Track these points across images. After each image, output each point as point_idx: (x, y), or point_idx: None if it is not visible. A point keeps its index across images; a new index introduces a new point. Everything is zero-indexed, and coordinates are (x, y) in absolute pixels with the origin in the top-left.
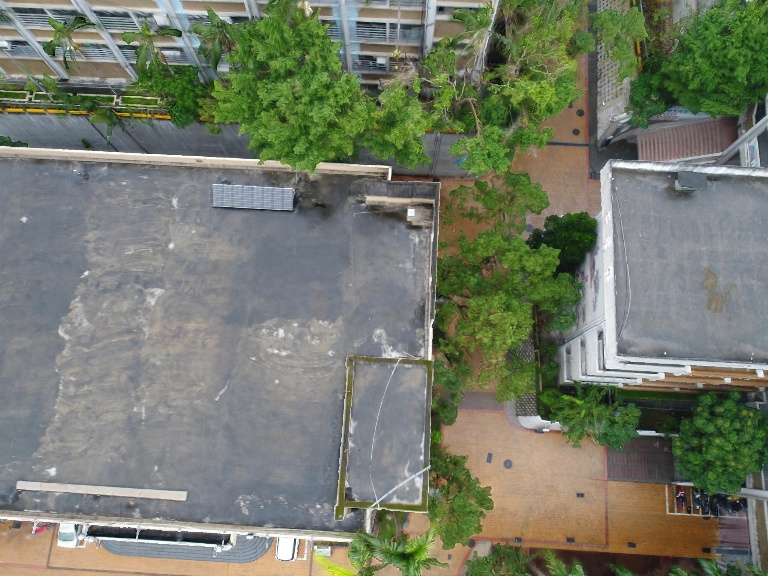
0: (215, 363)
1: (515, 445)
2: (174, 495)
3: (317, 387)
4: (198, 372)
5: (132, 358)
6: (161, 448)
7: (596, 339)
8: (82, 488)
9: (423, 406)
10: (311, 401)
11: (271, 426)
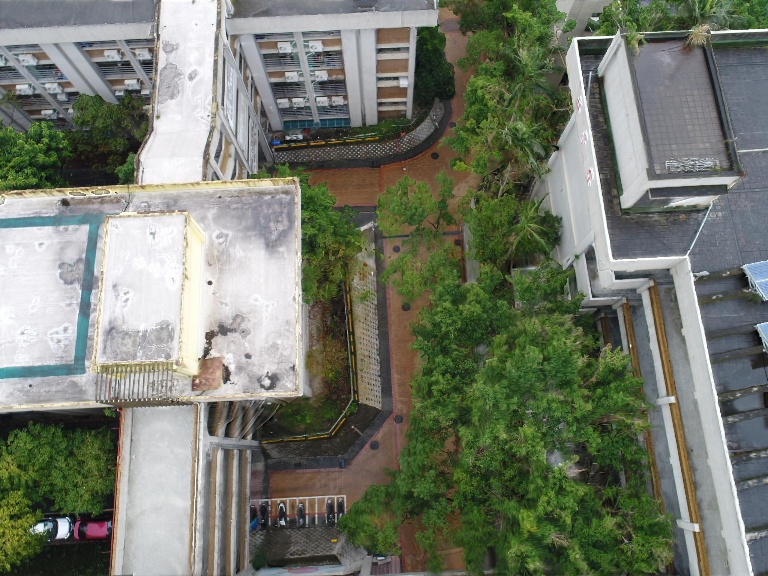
0: None
1: None
2: None
3: None
4: None
5: None
6: None
7: None
8: None
9: None
10: None
11: None
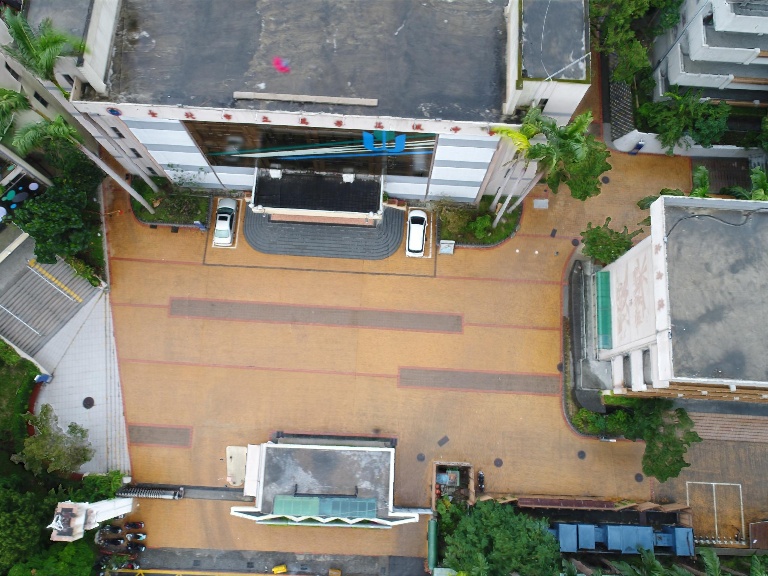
0: (392, 7)
1: (611, 165)
2: (367, 101)
3: (480, 25)
4: (378, 14)
5: (321, 4)
6: (352, 69)
7: (701, 21)
8: (289, 96)
9: (582, 12)
10: (476, 35)
11: (443, 53)
